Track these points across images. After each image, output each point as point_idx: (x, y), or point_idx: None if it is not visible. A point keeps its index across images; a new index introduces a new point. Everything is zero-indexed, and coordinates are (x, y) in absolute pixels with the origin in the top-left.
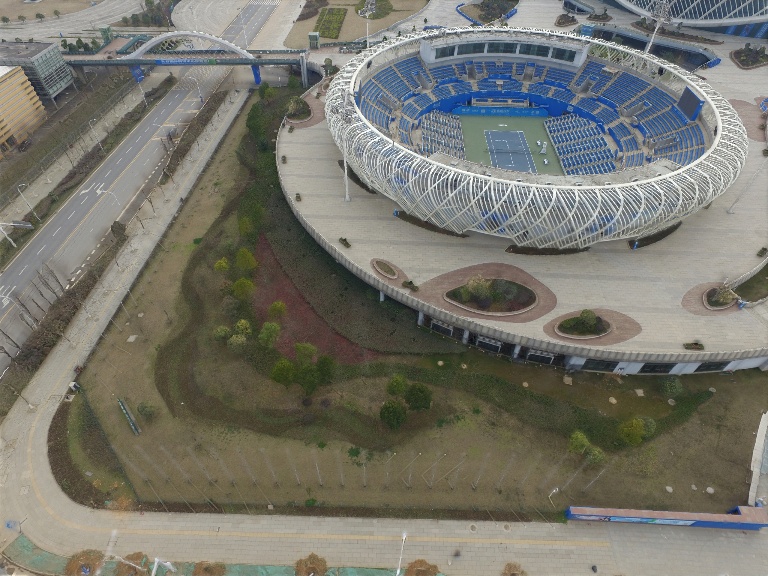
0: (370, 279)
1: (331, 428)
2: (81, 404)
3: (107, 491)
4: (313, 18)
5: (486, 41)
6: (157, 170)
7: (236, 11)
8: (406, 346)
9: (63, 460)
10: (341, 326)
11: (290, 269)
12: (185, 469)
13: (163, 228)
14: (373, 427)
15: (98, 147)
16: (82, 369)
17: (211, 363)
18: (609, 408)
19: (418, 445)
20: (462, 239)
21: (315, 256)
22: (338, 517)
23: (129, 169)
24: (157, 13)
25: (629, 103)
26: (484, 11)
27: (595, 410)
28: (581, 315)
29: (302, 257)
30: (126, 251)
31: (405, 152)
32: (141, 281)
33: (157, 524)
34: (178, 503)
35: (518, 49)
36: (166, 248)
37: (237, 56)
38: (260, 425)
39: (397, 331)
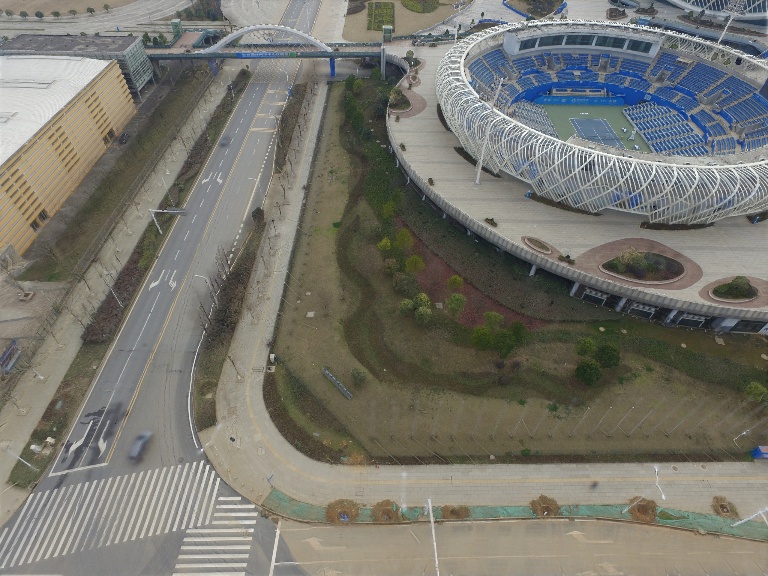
0: (527, 254)
1: (526, 387)
2: (285, 374)
3: (339, 449)
4: (362, 12)
5: (566, 33)
6: (267, 160)
7: (283, 5)
8: (568, 315)
9: (288, 423)
10: (503, 298)
11: (437, 248)
12: (406, 427)
13: (297, 214)
14: (563, 385)
15: (204, 138)
16: (273, 343)
17: (399, 334)
18: (764, 363)
19: (607, 400)
20: (597, 217)
21: (455, 236)
22: (554, 464)
23: (240, 159)
24: (207, 7)
25: (707, 91)
26: (531, 5)
27: (752, 365)
28: (735, 281)
29: (443, 237)
30: (269, 236)
31: (544, 137)
32: (296, 263)
33: (394, 475)
34: (407, 457)
35: (595, 41)
36: (307, 232)
37: (315, 49)
38: (462, 387)
39: (555, 302)
